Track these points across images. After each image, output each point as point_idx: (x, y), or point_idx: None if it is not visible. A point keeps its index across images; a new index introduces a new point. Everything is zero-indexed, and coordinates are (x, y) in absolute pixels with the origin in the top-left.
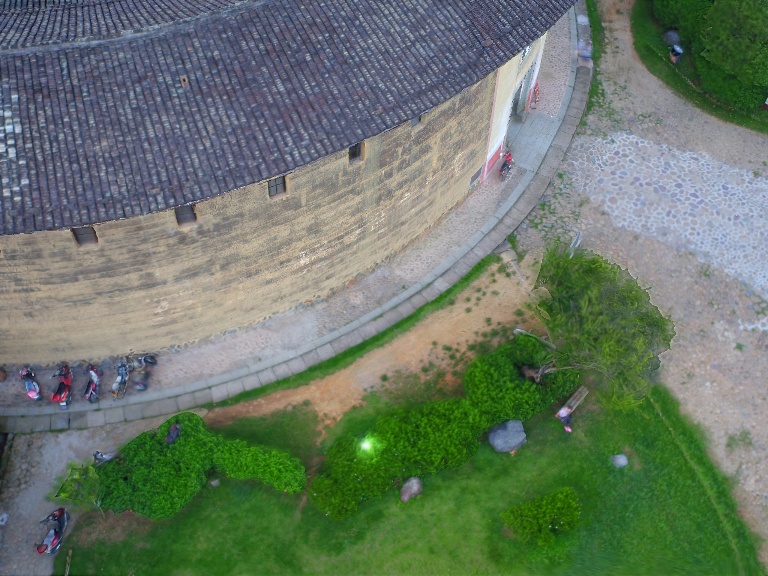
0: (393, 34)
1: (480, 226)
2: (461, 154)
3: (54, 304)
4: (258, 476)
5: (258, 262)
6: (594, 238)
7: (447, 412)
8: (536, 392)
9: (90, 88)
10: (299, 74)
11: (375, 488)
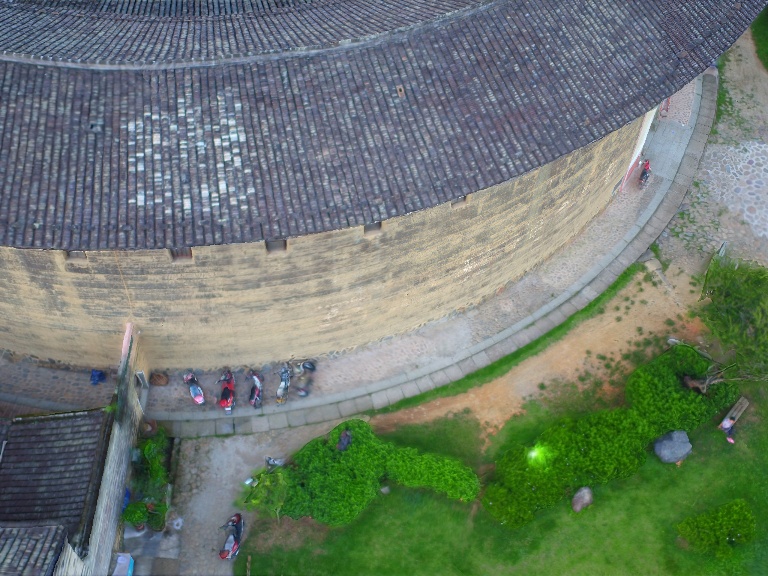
0: (595, 45)
1: (623, 234)
2: (614, 163)
3: (231, 310)
4: (432, 484)
5: (427, 270)
6: (736, 248)
7: (615, 422)
8: (702, 403)
9: (310, 97)
10: (509, 84)
11: (550, 498)
